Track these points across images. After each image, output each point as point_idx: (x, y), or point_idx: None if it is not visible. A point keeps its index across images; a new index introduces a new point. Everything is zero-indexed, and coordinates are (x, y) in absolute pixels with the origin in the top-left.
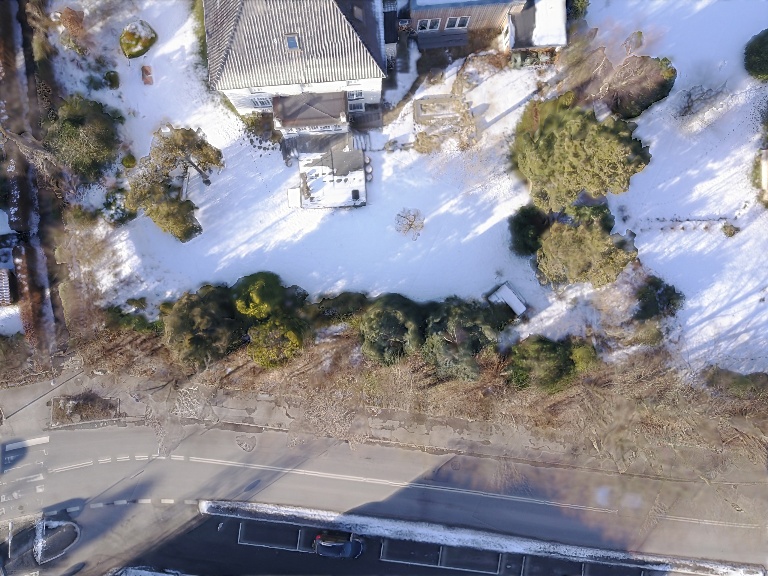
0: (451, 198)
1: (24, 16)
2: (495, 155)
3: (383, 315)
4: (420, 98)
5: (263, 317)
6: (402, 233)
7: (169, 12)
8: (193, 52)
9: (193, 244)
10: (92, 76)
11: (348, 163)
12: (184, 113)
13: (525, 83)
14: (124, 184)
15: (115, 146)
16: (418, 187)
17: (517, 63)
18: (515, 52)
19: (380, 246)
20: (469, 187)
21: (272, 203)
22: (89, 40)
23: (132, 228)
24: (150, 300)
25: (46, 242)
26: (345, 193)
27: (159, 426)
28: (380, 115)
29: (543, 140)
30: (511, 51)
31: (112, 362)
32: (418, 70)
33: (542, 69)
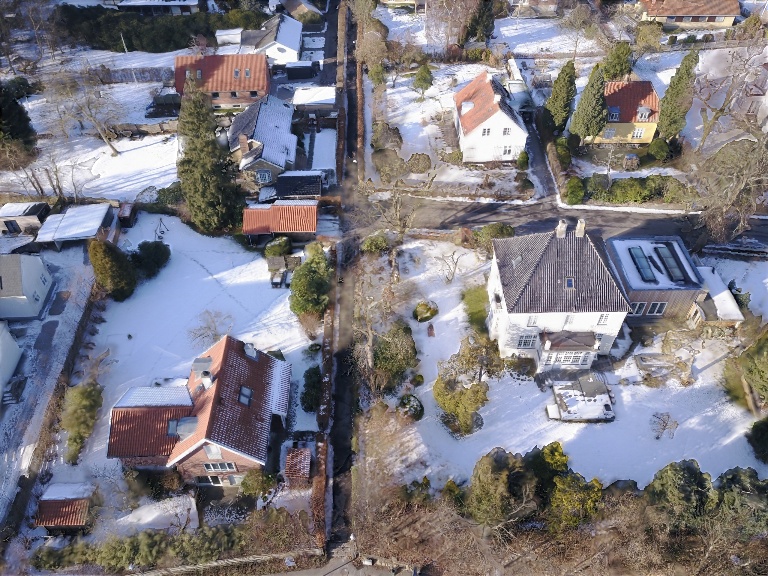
0: (688, 417)
1: (343, 300)
2: (714, 390)
3: (681, 463)
4: (639, 354)
5: (564, 470)
6: (653, 442)
7: (446, 300)
8: (464, 321)
9: (468, 443)
10: None
11: (594, 389)
12: None
13: (719, 347)
14: None
15: (415, 363)
16: (657, 409)
17: (709, 334)
18: (706, 326)
19: (635, 452)
20: (701, 410)
21: (533, 417)
22: (392, 310)
23: (418, 426)
24: (432, 484)
25: (336, 440)
26: (596, 409)
27: (481, 556)
28: (610, 363)
29: (766, 351)
30: (702, 326)
31: (385, 549)
32: (632, 338)
33: (728, 340)
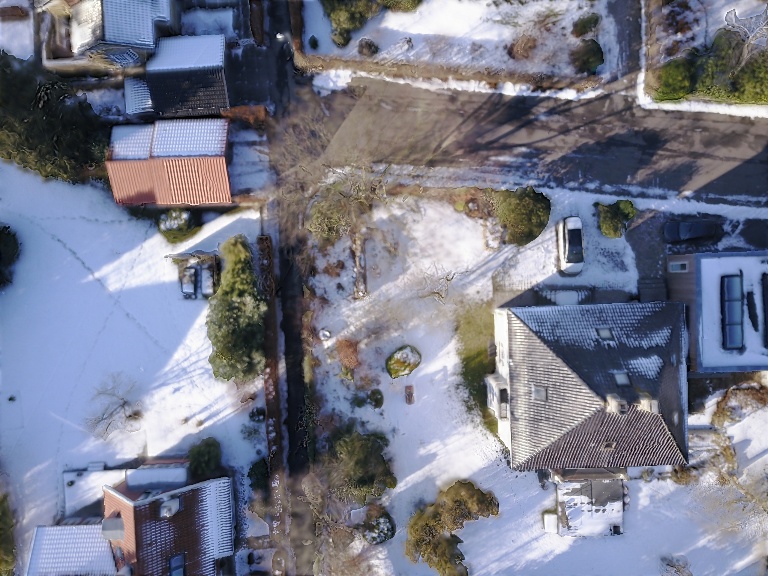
0: (709, 534)
1: (288, 326)
2: (755, 492)
3: None
4: None
5: None
6: (657, 564)
7: (433, 332)
8: (455, 373)
9: None
10: (358, 396)
11: (607, 494)
12: (444, 433)
13: None
14: (382, 500)
15: (386, 477)
16: (676, 520)
17: None
18: None
19: (634, 575)
20: (728, 524)
21: (525, 523)
22: None
23: (390, 546)
24: None
25: (297, 543)
26: (603, 524)
27: None
28: None
29: None
30: None
31: None
32: None
33: None
